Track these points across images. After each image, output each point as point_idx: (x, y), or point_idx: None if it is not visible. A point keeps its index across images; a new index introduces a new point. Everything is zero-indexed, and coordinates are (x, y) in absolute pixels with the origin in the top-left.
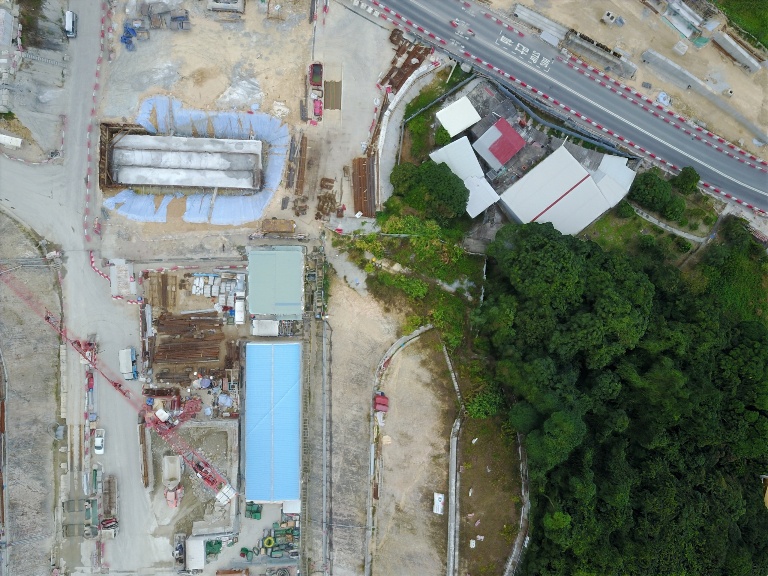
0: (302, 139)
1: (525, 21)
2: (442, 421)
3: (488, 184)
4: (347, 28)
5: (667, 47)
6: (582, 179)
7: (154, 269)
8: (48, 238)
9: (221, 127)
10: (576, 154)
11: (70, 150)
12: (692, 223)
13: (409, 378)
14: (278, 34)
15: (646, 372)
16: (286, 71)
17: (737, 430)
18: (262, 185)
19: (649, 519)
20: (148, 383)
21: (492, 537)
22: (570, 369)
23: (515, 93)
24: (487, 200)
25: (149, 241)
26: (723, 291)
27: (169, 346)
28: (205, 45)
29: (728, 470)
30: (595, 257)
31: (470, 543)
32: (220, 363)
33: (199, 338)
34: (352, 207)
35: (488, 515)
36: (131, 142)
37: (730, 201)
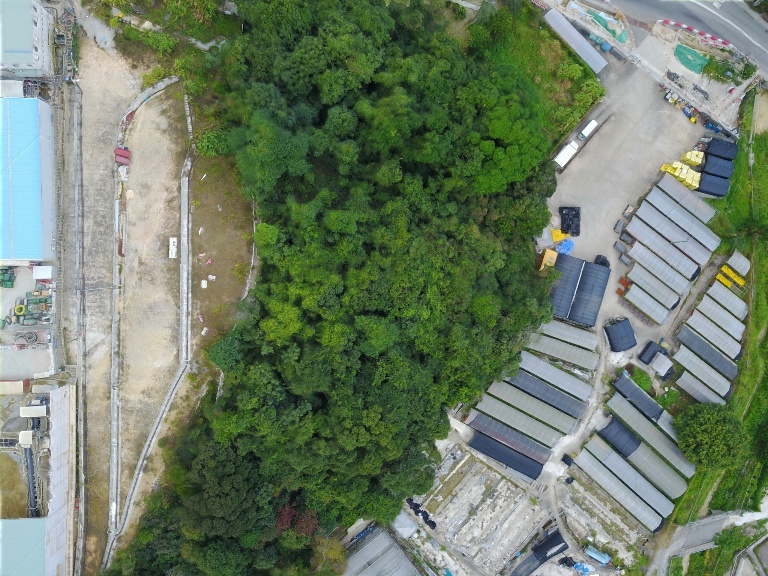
0: None
1: None
2: (175, 164)
3: None
4: None
5: None
6: None
7: None
8: None
9: None
10: None
11: None
12: None
13: (150, 129)
14: None
15: None
16: None
17: (472, 160)
18: None
19: (383, 253)
20: None
21: (224, 277)
22: (302, 103)
23: None
24: None
25: None
26: (500, 59)
27: None
28: None
29: (494, 230)
30: None
31: (201, 283)
32: None
33: None
34: None
35: (220, 255)
36: None
37: None
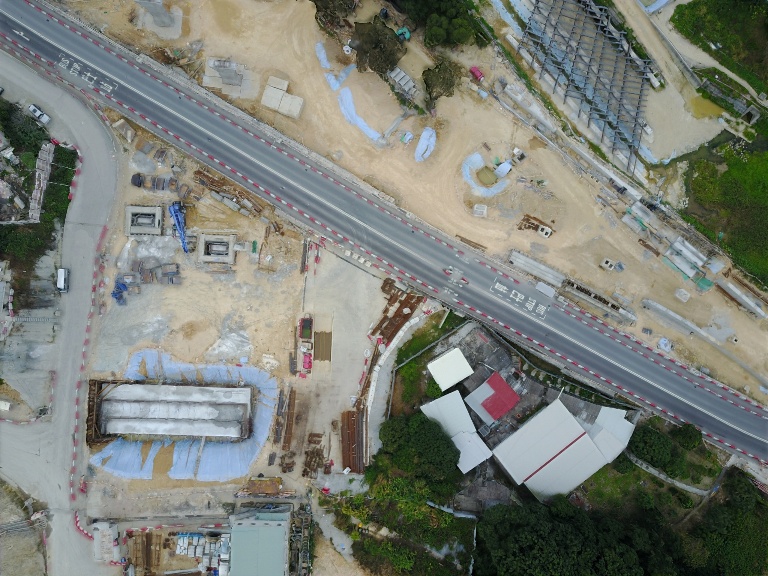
0: (291, 393)
1: (520, 268)
2: None
3: (480, 439)
4: (338, 277)
5: (669, 291)
6: (578, 437)
7: (139, 528)
8: (34, 496)
9: (210, 375)
10: (572, 407)
11: (59, 406)
12: (694, 477)
13: None
14: (268, 285)
15: None
16: (276, 323)
17: None
18: (250, 433)
19: None
20: None
21: None
22: None
23: (510, 341)
24: (479, 456)
25: (134, 499)
26: (727, 551)
27: None
28: (195, 297)
29: None
30: (587, 555)
31: None
32: None
33: None
34: (340, 462)
35: None
36: (120, 392)
37: (735, 452)
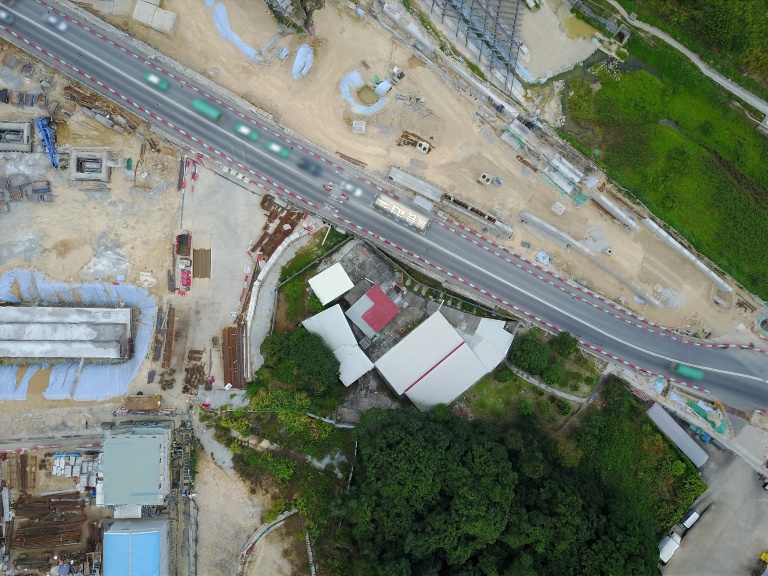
0: (169, 310)
1: (400, 184)
2: None
3: (362, 352)
4: (217, 194)
5: (546, 206)
6: (457, 346)
7: (13, 450)
8: None
9: (88, 296)
10: (452, 318)
11: None
12: (572, 384)
13: (271, 568)
14: (145, 202)
15: (506, 569)
16: (153, 240)
17: None
18: (131, 354)
19: None
20: (4, 570)
21: None
22: (429, 567)
23: (391, 256)
24: (361, 369)
25: (8, 420)
26: (604, 454)
27: (27, 531)
28: (69, 216)
29: None
30: (454, 449)
31: None
32: (82, 546)
33: (59, 521)
34: (222, 378)
35: None
36: None
37: (611, 360)
